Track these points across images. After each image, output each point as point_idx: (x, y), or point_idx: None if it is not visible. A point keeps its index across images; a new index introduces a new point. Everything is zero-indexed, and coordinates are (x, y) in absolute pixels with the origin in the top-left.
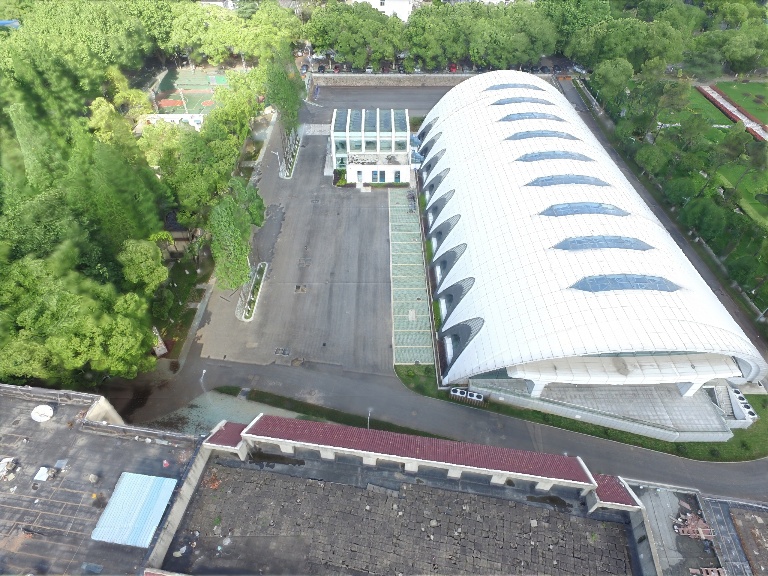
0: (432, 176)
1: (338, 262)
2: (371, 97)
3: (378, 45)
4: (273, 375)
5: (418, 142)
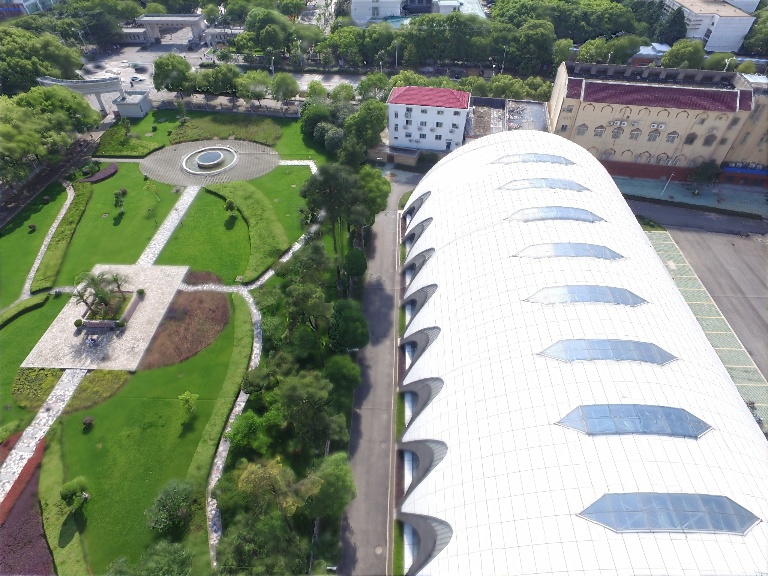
0: None
1: None
2: None
3: None
4: (755, 228)
5: None
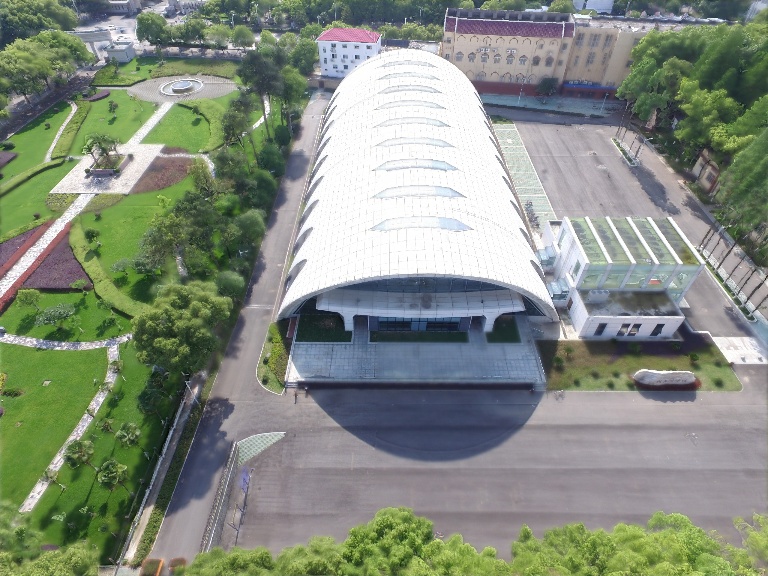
0: None
1: (576, 167)
2: (724, 496)
3: None
4: (578, 121)
5: (550, 284)
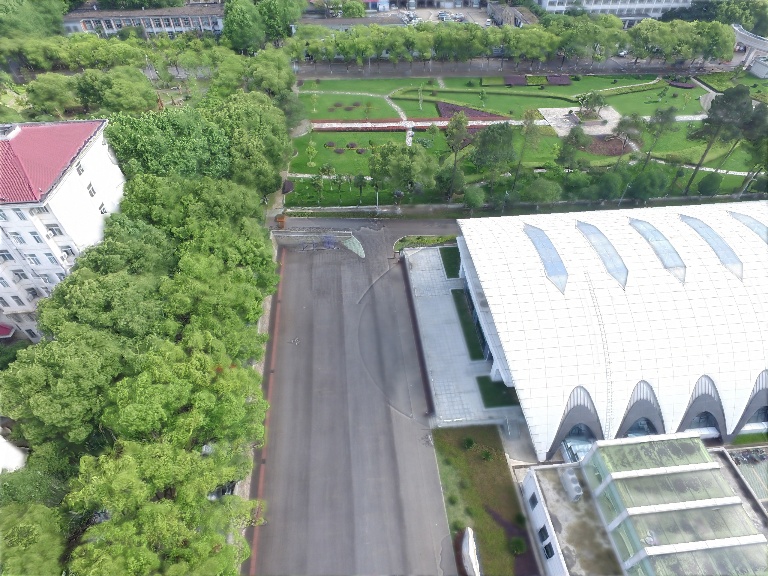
0: (740, 410)
1: None
2: None
3: (222, 543)
4: None
5: (588, 444)
